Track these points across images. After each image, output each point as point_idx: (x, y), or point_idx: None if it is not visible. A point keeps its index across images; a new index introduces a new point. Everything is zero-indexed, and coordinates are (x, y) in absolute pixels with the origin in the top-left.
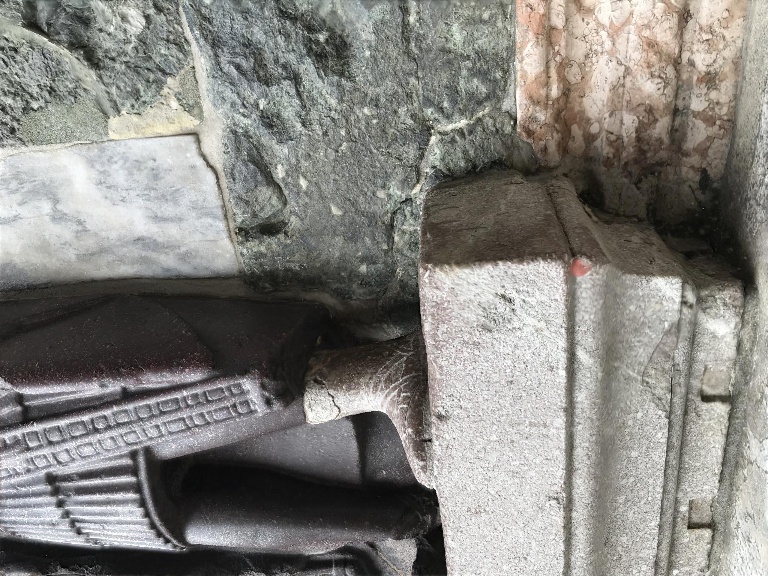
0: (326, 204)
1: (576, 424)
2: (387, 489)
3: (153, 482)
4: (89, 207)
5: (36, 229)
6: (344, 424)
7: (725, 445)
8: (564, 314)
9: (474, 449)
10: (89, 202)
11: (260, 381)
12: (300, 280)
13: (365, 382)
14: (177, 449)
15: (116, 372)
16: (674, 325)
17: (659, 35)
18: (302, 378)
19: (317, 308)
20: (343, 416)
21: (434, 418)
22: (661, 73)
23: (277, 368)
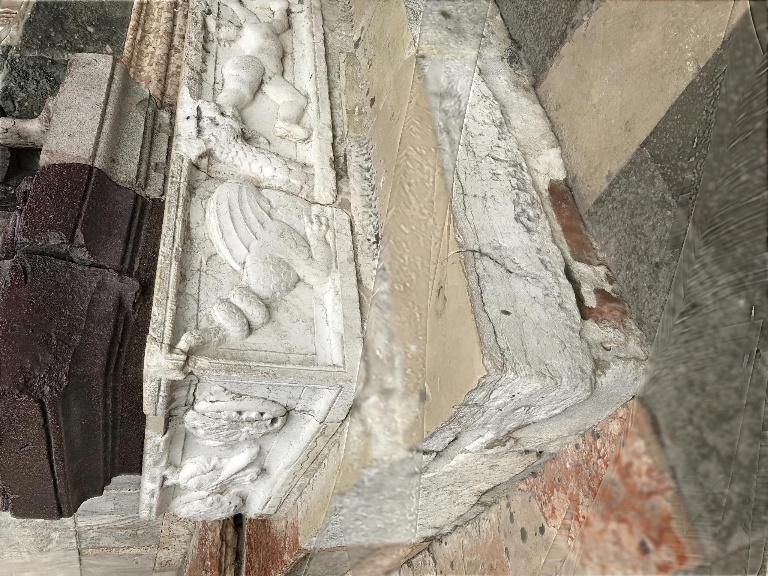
0: (33, 111)
1: None
2: None
3: None
4: None
5: None
6: (5, 161)
7: None
8: (111, 64)
9: None
10: None
11: None
12: None
13: None
14: None
15: None
16: (147, 100)
17: (155, 92)
18: None
19: None
20: (14, 130)
21: None
22: (156, 100)
23: None
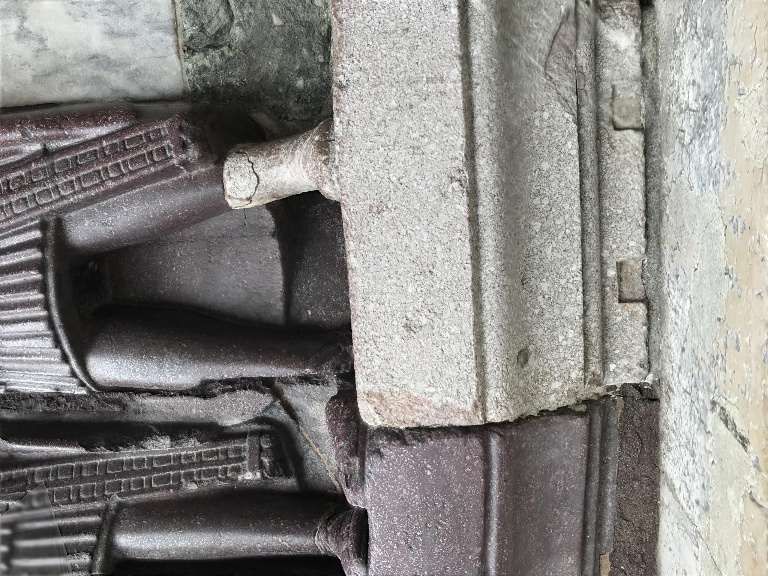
0: (268, 14)
1: (474, 86)
2: (311, 331)
3: (59, 268)
4: (53, 25)
5: (1, 49)
6: (269, 244)
7: (645, 188)
8: None
9: (374, 123)
10: (54, 19)
11: (179, 124)
12: (240, 97)
13: (285, 147)
14: (90, 227)
15: (41, 120)
16: (571, 14)
17: None
18: (225, 152)
19: (252, 119)
20: (263, 195)
21: (335, 89)
22: None
23: (198, 120)
